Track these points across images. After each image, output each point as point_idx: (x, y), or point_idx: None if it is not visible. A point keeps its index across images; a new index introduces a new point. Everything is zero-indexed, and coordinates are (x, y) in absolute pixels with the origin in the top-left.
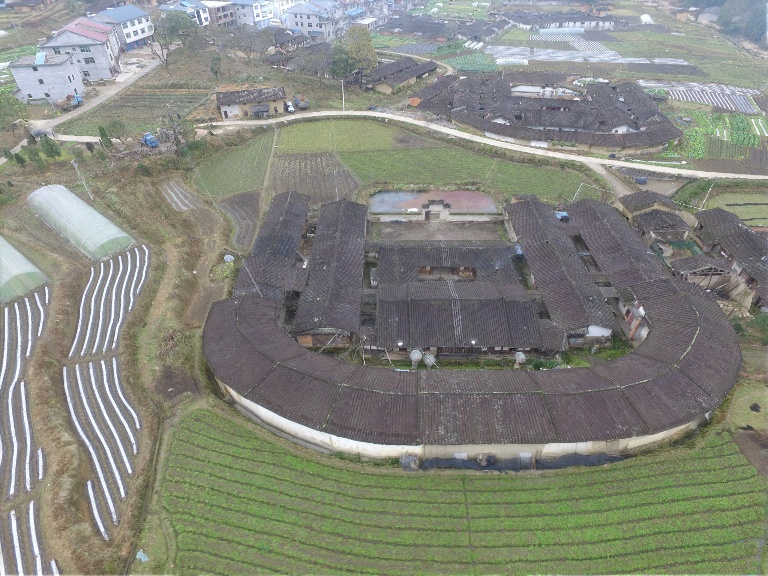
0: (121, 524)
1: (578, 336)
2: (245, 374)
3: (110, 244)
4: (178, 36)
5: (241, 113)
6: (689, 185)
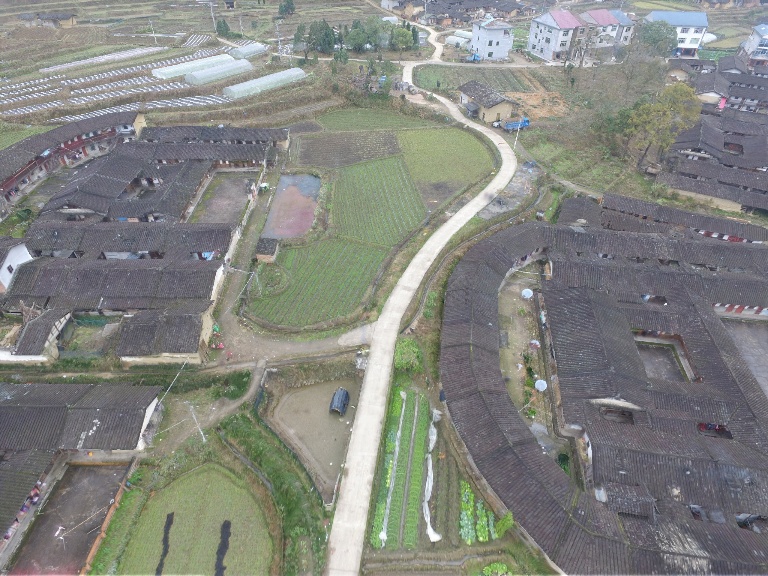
0: None
1: None
2: None
3: None
4: None
5: None
6: (303, 474)
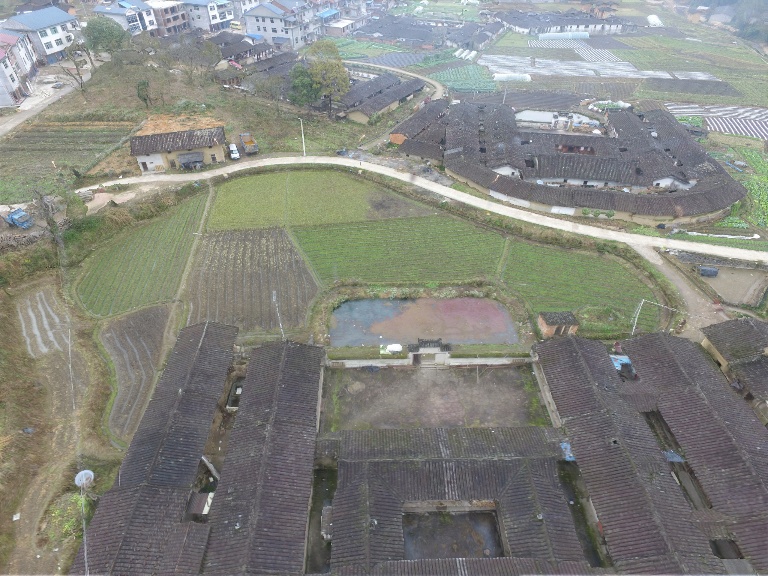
0: None
1: None
2: None
3: None
4: None
5: (166, 163)
6: None
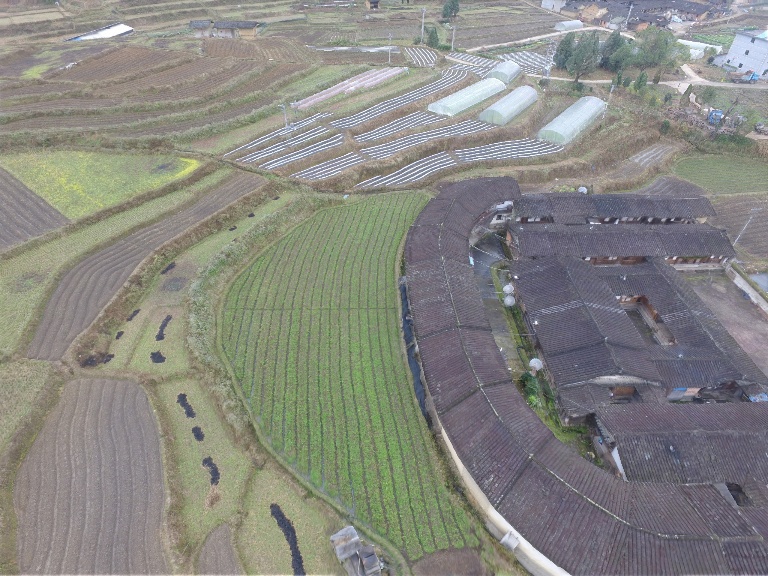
0: None
1: None
2: None
3: (551, 133)
4: None
5: None
6: None
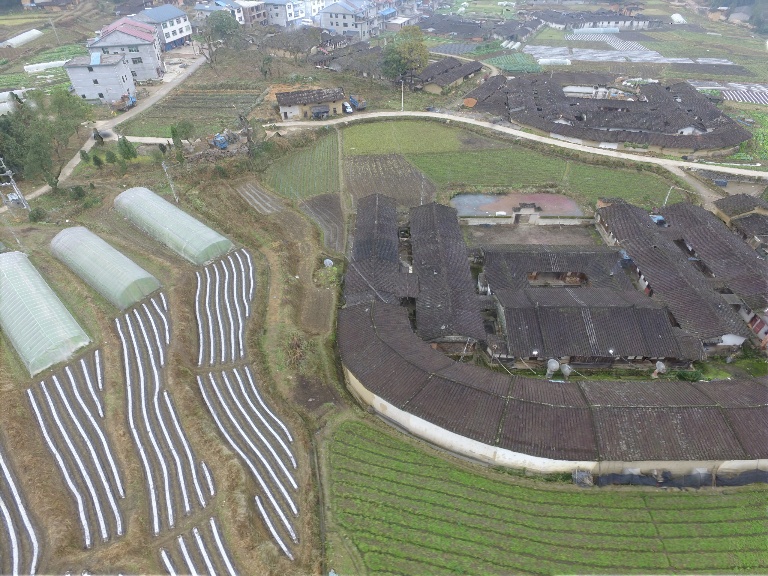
0: (301, 542)
1: (710, 345)
2: (397, 385)
3: (212, 248)
4: (221, 36)
5: (301, 114)
6: None
